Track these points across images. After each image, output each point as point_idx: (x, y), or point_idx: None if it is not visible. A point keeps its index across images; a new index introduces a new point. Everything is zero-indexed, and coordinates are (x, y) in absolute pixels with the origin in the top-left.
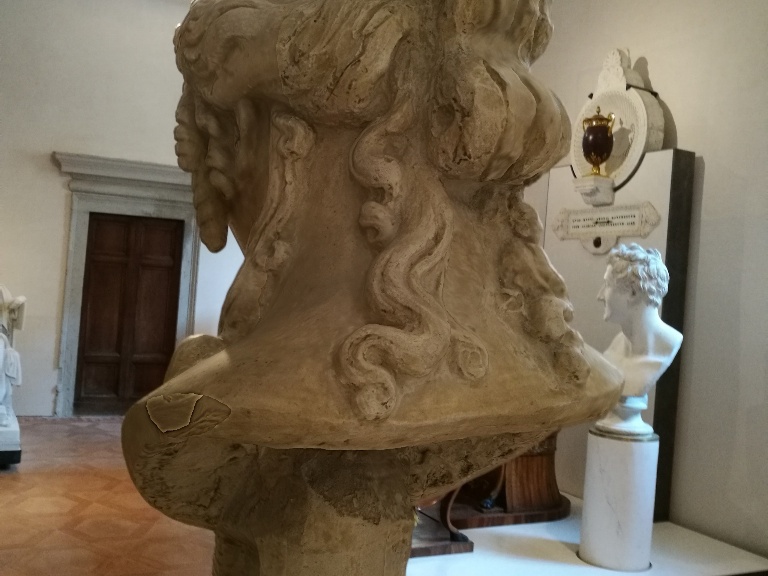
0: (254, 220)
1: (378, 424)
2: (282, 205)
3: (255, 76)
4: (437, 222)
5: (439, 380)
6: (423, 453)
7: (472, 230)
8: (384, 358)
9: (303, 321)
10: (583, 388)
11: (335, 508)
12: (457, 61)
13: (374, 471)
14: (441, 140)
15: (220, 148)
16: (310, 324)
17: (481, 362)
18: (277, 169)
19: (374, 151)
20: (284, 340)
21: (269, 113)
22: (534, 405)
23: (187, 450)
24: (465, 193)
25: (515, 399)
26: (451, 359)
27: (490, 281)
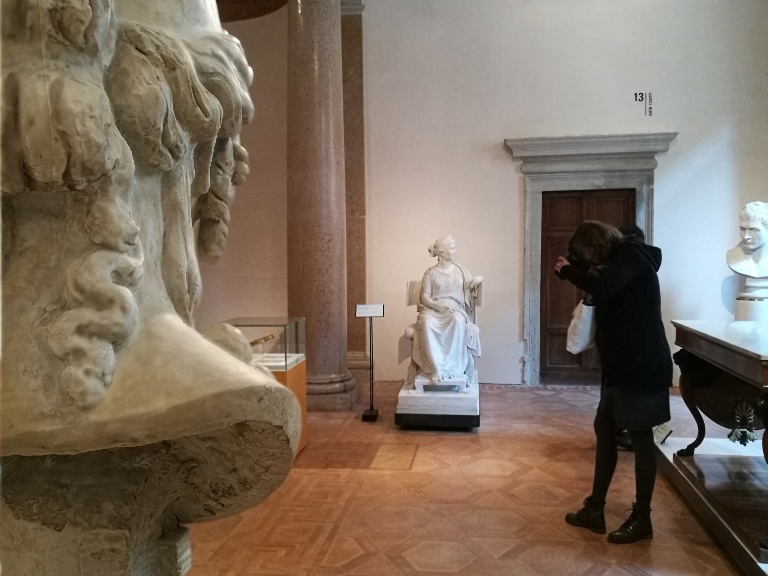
0: None
1: None
2: None
3: None
4: None
5: None
6: (183, 462)
7: (55, 242)
8: None
9: None
10: (89, 411)
11: (13, 511)
12: None
13: (75, 479)
14: None
15: None
16: None
17: None
18: None
19: None
20: None
21: None
22: (14, 429)
23: None
24: (52, 204)
25: None
26: None
27: (48, 295)
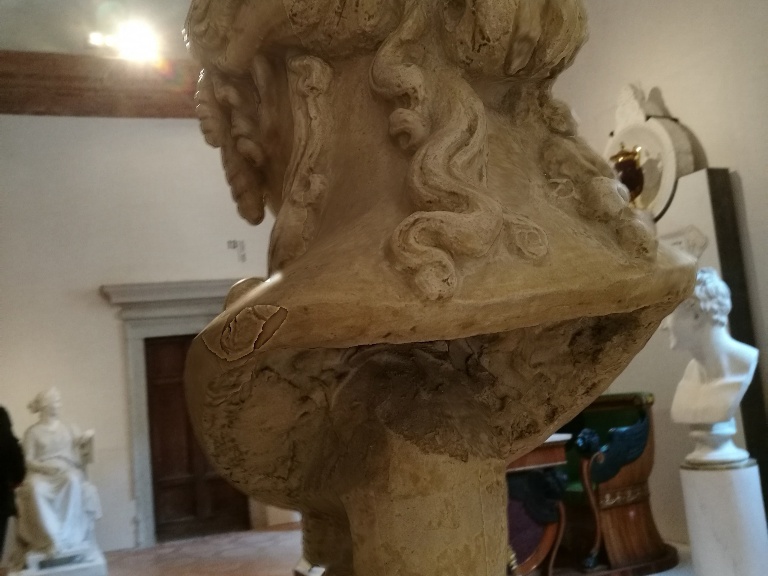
0: None
1: (443, 304)
2: (310, 140)
3: (264, 24)
4: (468, 115)
5: (499, 261)
6: (502, 399)
7: (507, 133)
8: (437, 241)
9: (348, 230)
10: (654, 262)
11: (418, 446)
12: None
13: (453, 410)
14: (457, 32)
15: (243, 117)
16: (356, 231)
17: (540, 241)
18: (300, 109)
19: (392, 62)
20: (332, 247)
21: (284, 66)
22: (605, 279)
23: (254, 403)
24: (493, 99)
25: (584, 274)
26: (508, 241)
27: (535, 176)
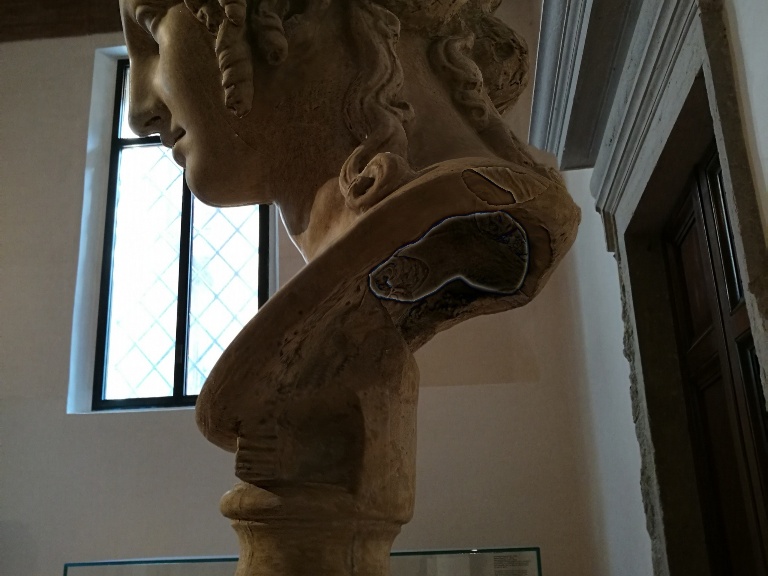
0: (291, 94)
1: None
2: (398, 73)
3: None
4: None
5: None
6: None
7: None
8: None
9: (489, 154)
10: None
11: None
12: (497, 19)
13: None
14: (504, 65)
15: None
16: None
17: None
18: (382, 44)
19: None
20: None
21: (341, 0)
22: None
23: None
24: None
25: None
26: None
27: None
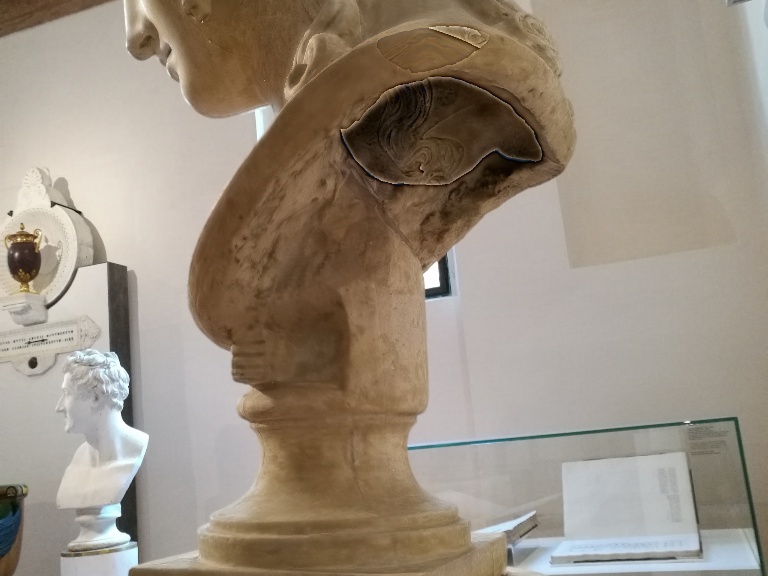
0: None
1: None
2: None
3: None
4: None
5: None
6: None
7: None
8: None
9: (449, 13)
10: None
11: (409, 248)
12: None
13: None
14: None
15: None
16: None
17: None
18: None
19: None
20: (457, 16)
21: None
22: None
23: None
24: None
25: None
26: None
27: None
